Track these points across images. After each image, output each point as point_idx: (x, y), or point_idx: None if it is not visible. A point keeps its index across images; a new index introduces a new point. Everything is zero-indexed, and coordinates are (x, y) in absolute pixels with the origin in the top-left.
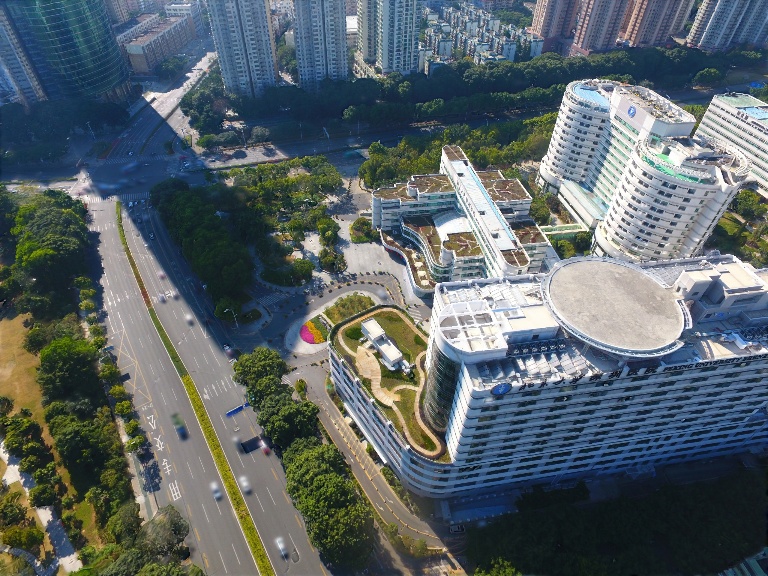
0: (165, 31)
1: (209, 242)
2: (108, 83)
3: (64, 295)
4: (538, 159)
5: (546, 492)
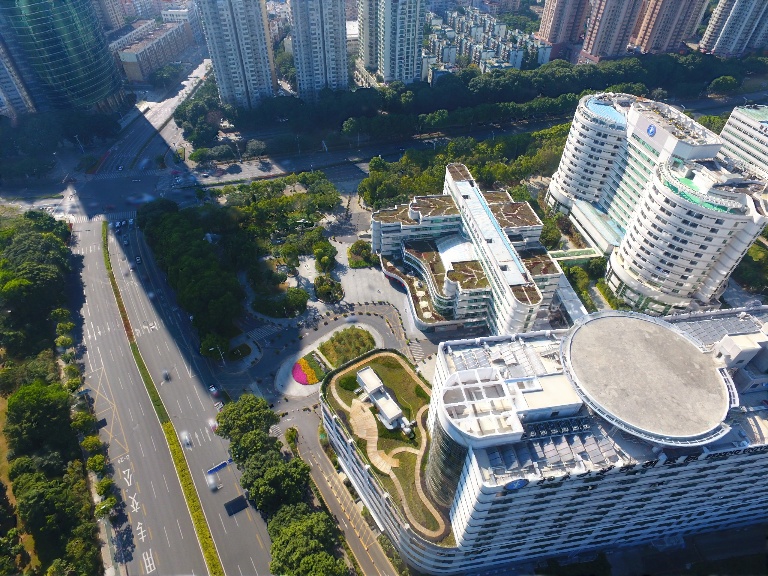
0: (160, 38)
1: (195, 272)
2: (99, 93)
3: (41, 327)
4: (547, 174)
5: (562, 566)
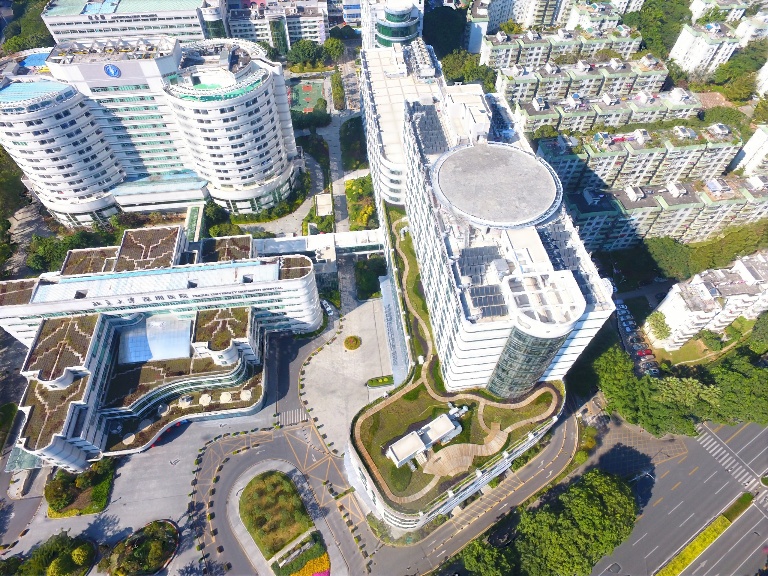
0: None
1: None
2: None
3: None
4: (13, 210)
5: None
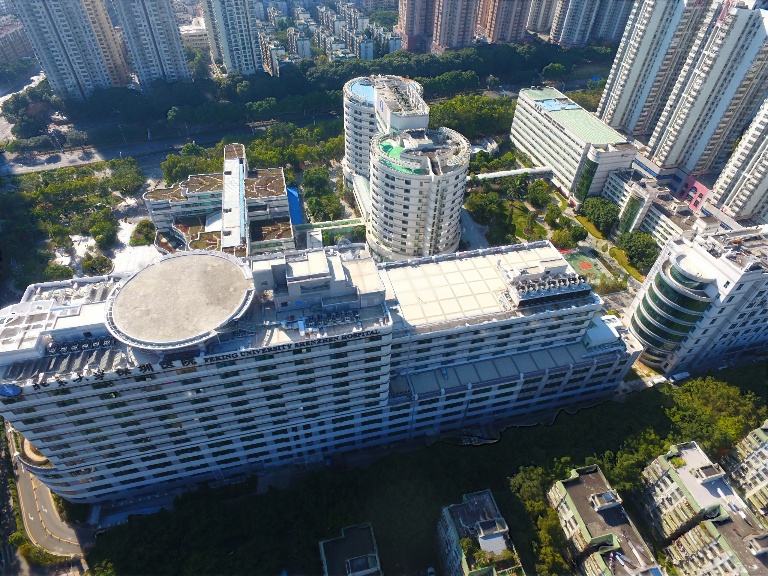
0: (8, 33)
1: None
2: None
3: None
4: None
5: (213, 489)
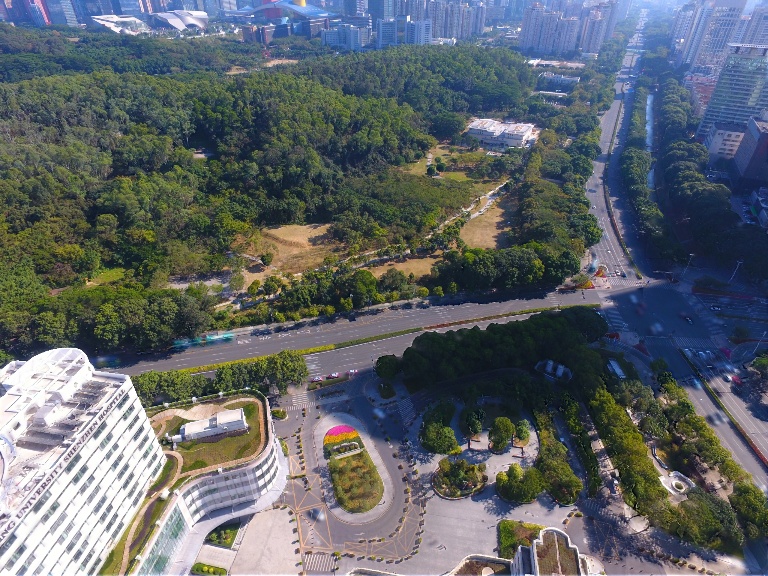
0: None
1: (458, 337)
2: None
3: None
4: None
5: None
